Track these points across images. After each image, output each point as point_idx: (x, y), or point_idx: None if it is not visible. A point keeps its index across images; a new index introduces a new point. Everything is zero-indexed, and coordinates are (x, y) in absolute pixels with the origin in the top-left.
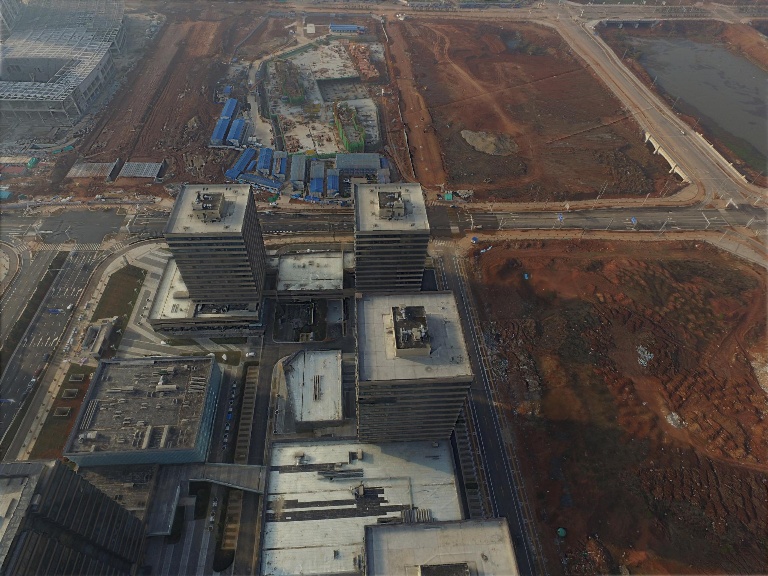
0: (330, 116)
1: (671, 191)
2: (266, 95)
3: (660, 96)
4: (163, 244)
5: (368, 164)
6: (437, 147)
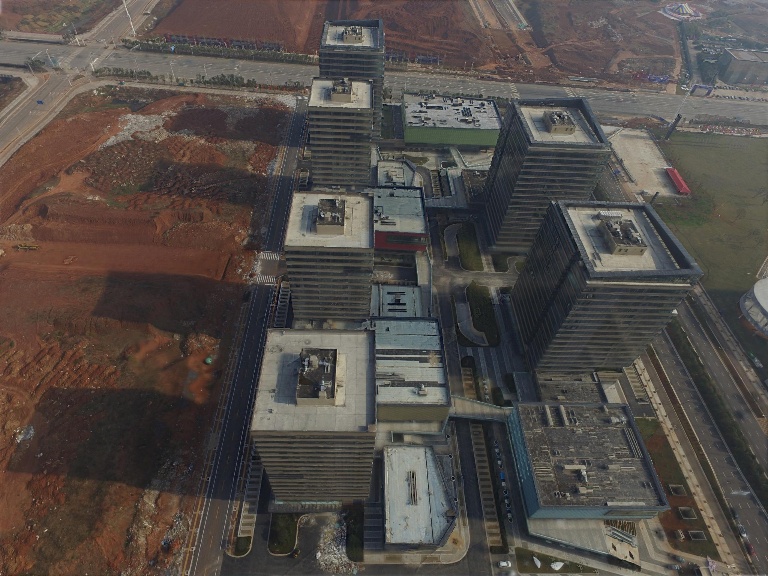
0: None
1: None
2: None
3: None
4: None
5: None
6: None
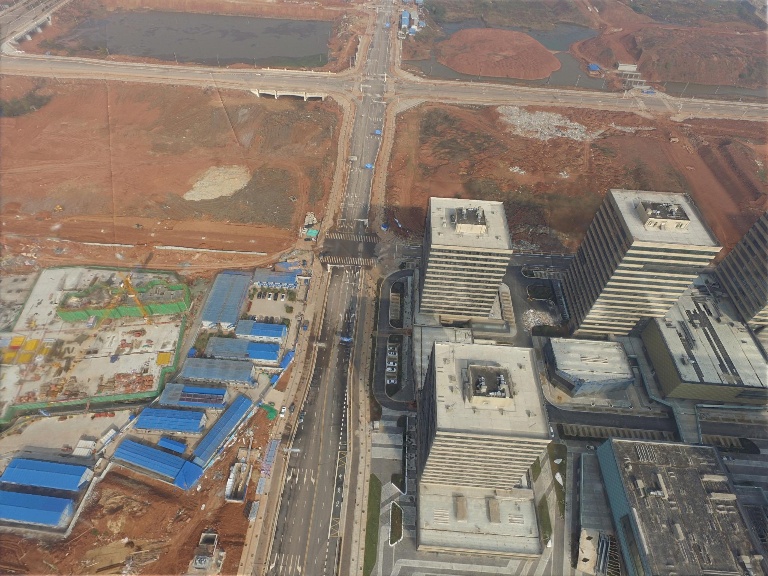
0: (66, 326)
1: None
2: None
3: (193, 65)
4: None
5: (239, 287)
6: (211, 224)
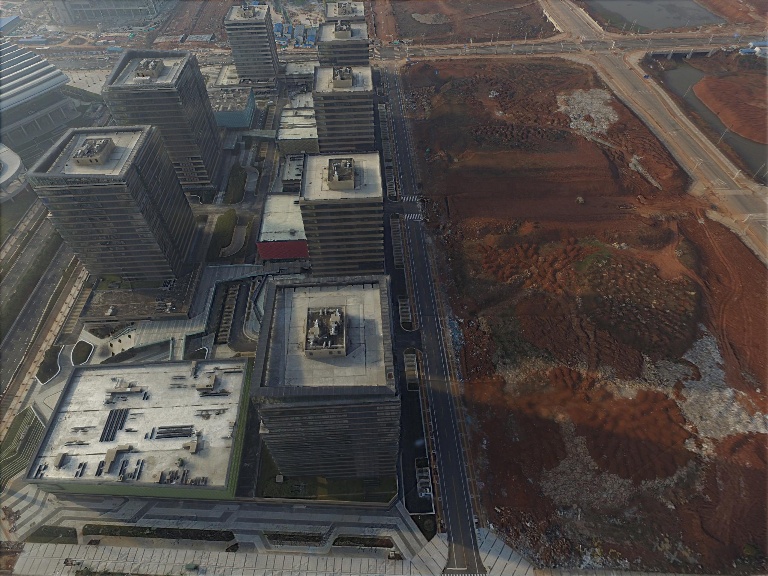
0: None
1: (547, 36)
2: (279, 1)
3: None
4: (217, 67)
5: None
6: (393, 22)
